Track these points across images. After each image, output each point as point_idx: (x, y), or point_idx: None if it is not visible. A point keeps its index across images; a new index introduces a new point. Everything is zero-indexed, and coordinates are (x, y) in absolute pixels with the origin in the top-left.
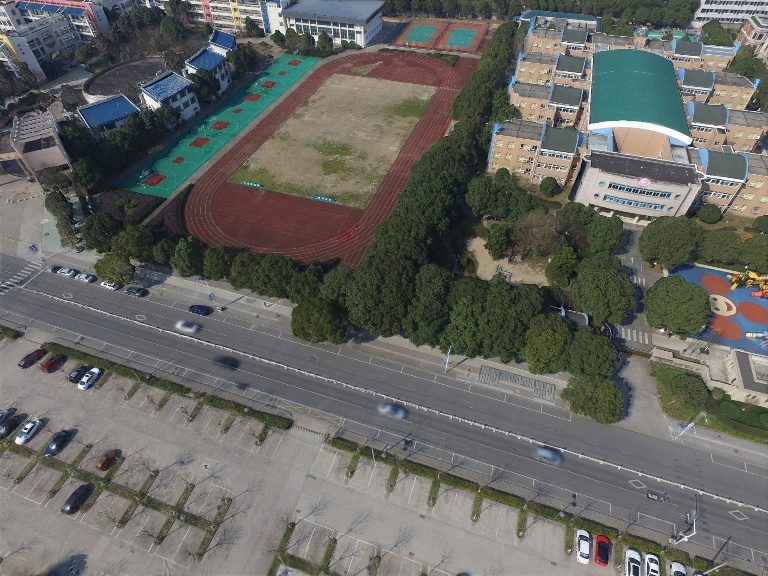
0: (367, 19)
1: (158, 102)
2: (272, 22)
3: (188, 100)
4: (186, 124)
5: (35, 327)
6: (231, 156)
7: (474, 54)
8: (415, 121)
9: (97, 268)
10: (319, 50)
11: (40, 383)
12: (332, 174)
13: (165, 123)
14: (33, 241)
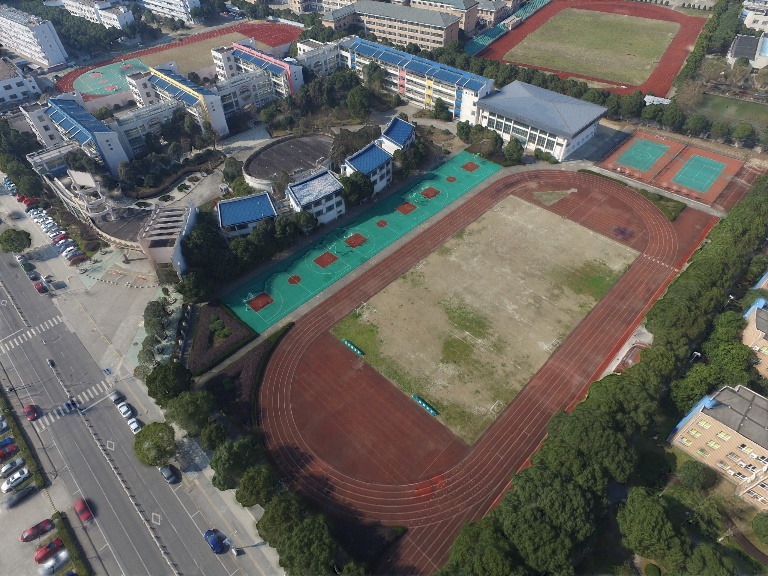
0: (575, 134)
1: (299, 207)
2: (464, 109)
3: (333, 204)
4: (323, 228)
5: (64, 480)
6: (349, 292)
7: (710, 206)
8: (589, 305)
9: (136, 441)
10: (504, 156)
11: (26, 574)
12: (451, 364)
13: (300, 227)
14: (121, 348)
